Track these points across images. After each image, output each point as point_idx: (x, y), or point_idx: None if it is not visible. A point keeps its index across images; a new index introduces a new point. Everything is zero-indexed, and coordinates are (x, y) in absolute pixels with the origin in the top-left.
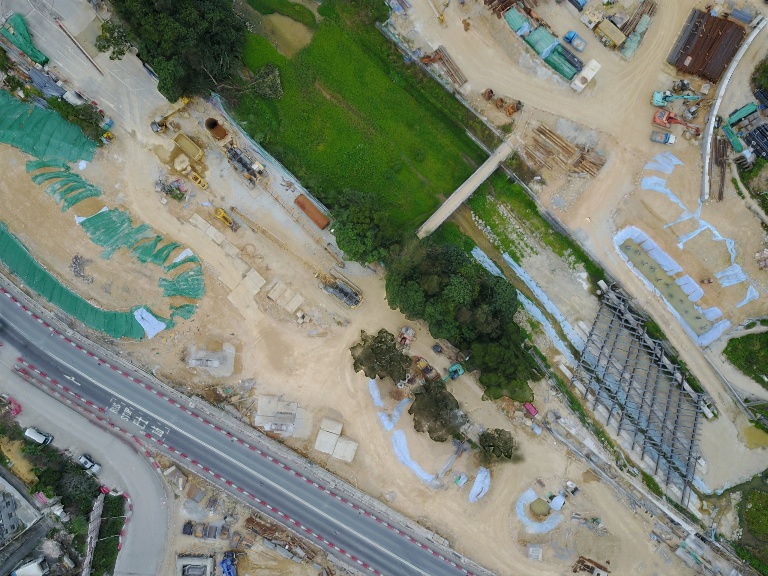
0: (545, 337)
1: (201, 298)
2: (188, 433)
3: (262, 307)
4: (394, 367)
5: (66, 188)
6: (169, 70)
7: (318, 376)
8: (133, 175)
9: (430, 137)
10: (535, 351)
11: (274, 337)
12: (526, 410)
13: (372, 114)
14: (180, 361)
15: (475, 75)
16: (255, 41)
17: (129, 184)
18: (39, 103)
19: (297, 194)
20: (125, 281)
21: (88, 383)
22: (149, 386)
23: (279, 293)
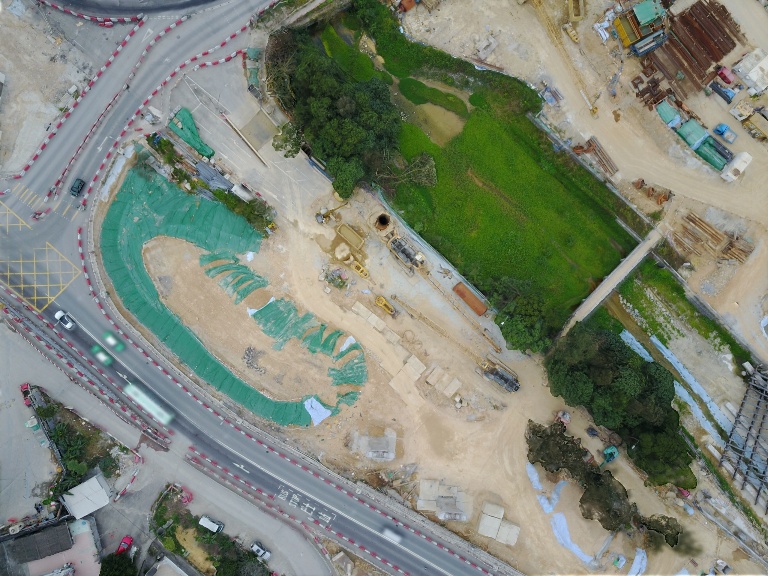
0: (692, 417)
1: (364, 385)
2: (354, 519)
3: (423, 393)
4: (576, 462)
5: (237, 280)
6: (351, 172)
7: (477, 460)
8: (297, 265)
9: (579, 223)
10: (684, 432)
11: (435, 422)
12: (678, 490)
13: (524, 201)
14: (343, 447)
15: (626, 164)
16: (410, 131)
17: (293, 274)
18: (206, 195)
19: (454, 281)
20: (296, 372)
21: (257, 471)
22: (316, 473)
23: (437, 378)
